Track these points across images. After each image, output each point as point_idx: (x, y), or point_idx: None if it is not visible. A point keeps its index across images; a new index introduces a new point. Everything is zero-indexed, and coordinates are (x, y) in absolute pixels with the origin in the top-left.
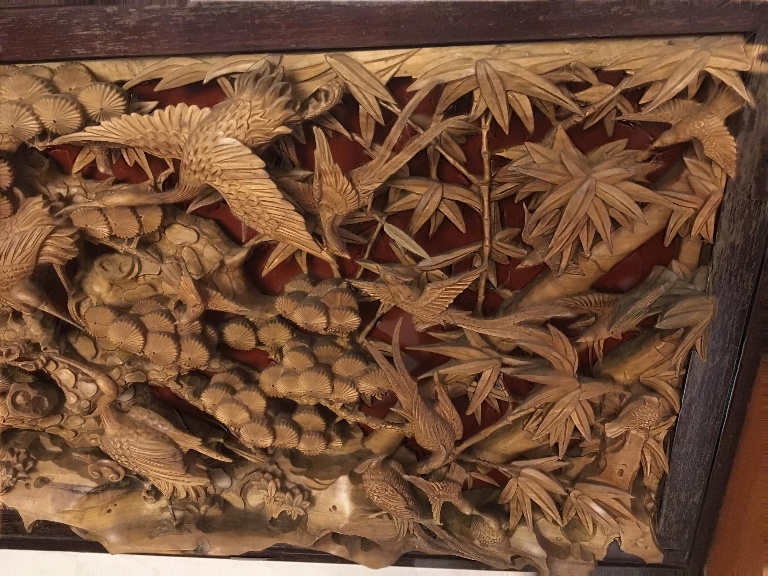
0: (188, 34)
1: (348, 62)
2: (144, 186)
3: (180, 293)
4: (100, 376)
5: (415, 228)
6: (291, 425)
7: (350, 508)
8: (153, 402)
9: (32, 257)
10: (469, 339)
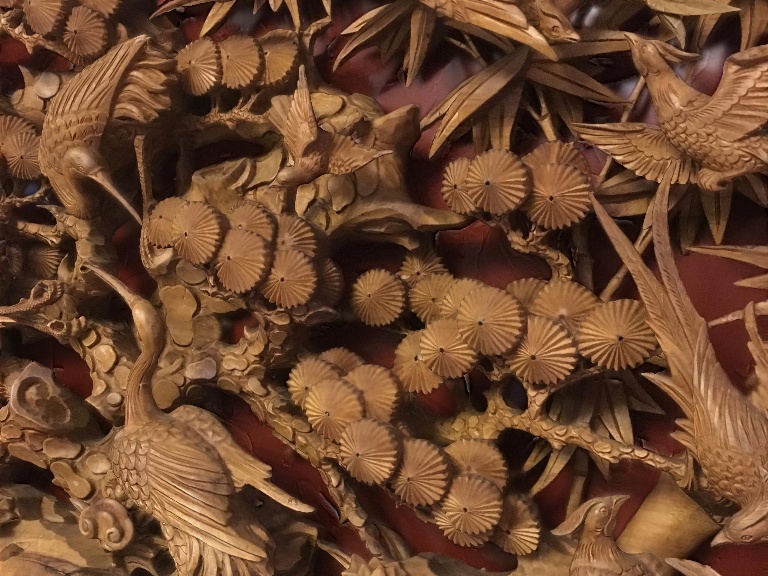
0: None
1: None
2: (284, 30)
3: (288, 131)
4: (140, 301)
5: (709, 19)
6: (437, 448)
7: None
8: None
9: (106, 98)
10: None
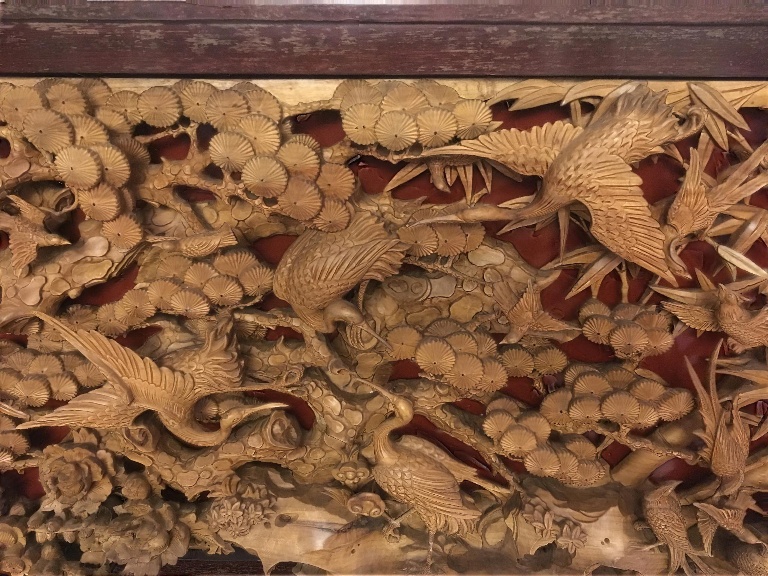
0: (561, 57)
1: (712, 90)
2: (464, 205)
3: (513, 311)
4: (401, 399)
5: None
6: None
7: (624, 540)
8: (392, 434)
9: (363, 272)
10: (767, 363)
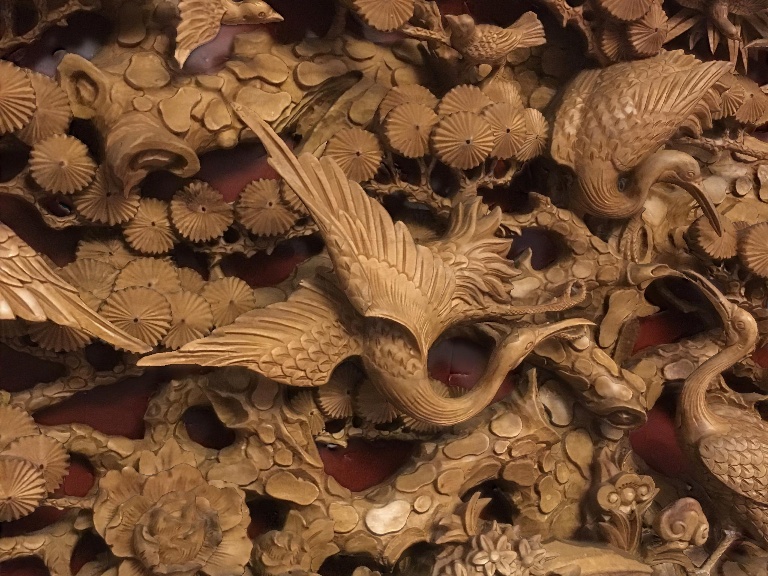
0: None
1: None
2: None
3: None
4: (742, 309)
5: None
6: None
7: None
8: (634, 452)
9: (692, 108)
10: None
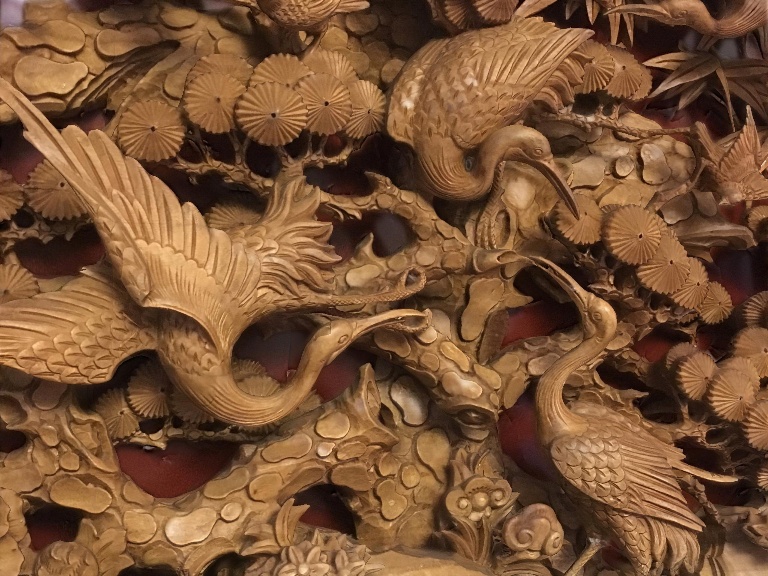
0: None
1: None
2: None
3: (729, 157)
4: (600, 298)
5: None
6: None
7: None
8: (504, 452)
9: (544, 79)
10: None
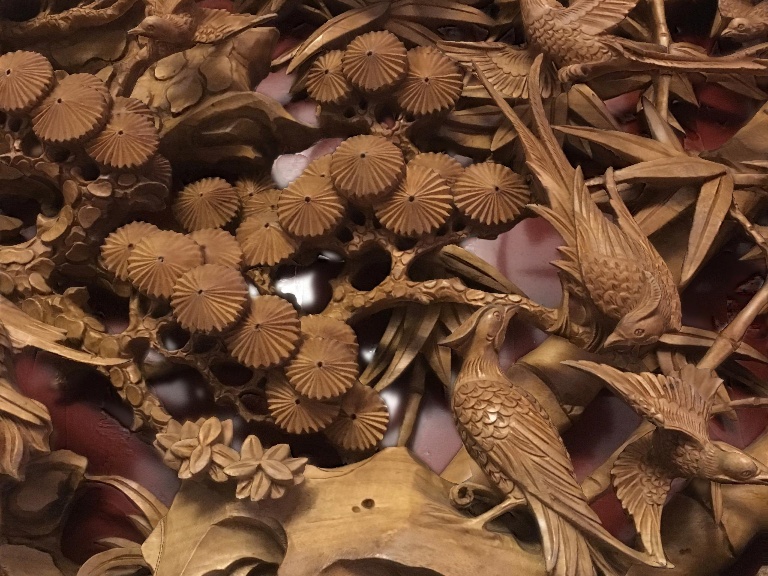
0: None
1: None
2: None
3: None
4: None
5: None
6: None
7: (413, 500)
8: None
9: None
10: (662, 141)
